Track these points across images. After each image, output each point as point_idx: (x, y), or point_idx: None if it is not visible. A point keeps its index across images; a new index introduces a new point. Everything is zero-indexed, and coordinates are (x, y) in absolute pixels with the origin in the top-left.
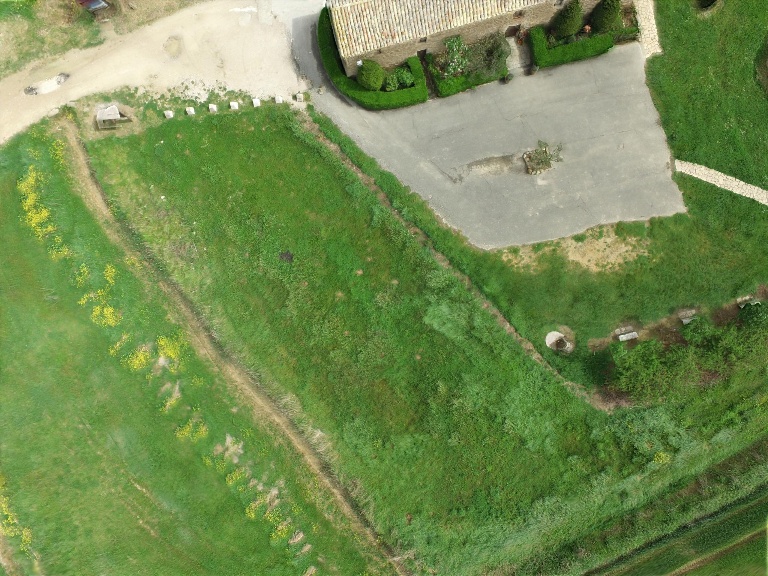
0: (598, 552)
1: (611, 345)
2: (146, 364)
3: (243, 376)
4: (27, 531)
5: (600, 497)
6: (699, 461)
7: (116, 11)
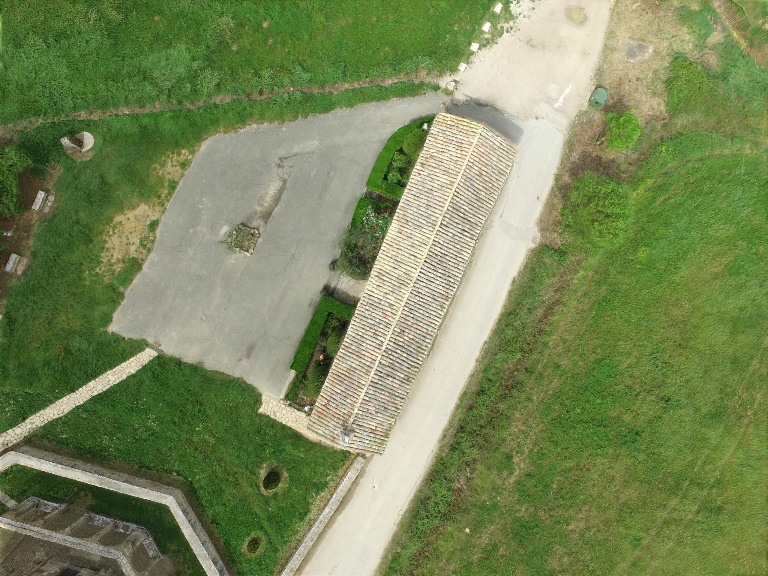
0: None
1: None
2: None
3: None
4: None
5: None
6: None
7: None
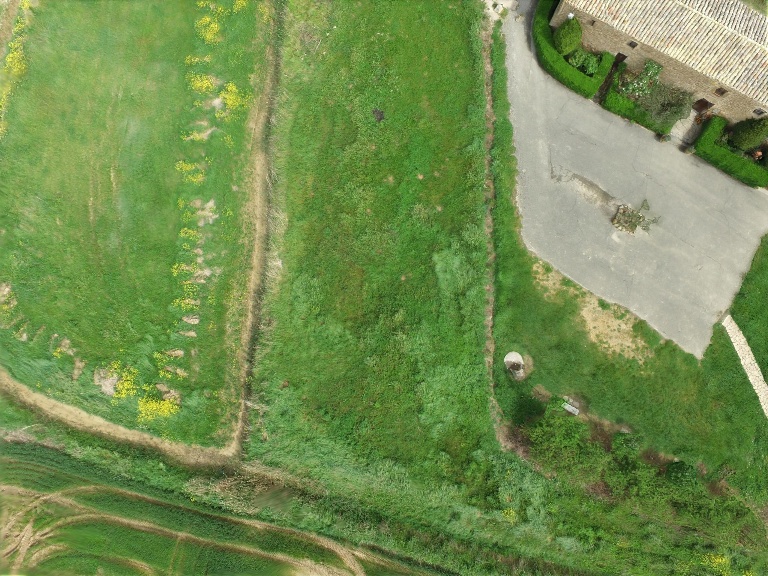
0: (398, 540)
1: (555, 395)
2: (203, 93)
3: (264, 169)
4: (4, 131)
5: (438, 501)
6: (535, 545)
7: None
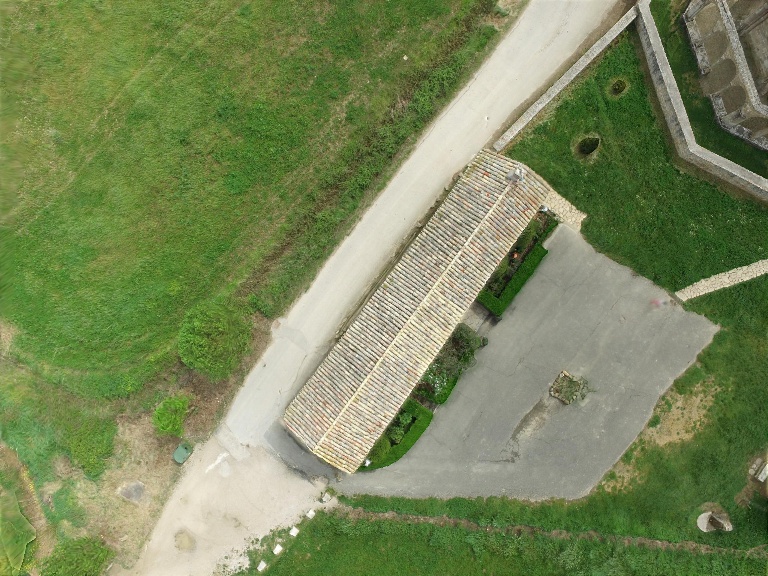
0: None
1: None
2: None
3: None
4: None
5: None
6: None
7: (112, 552)
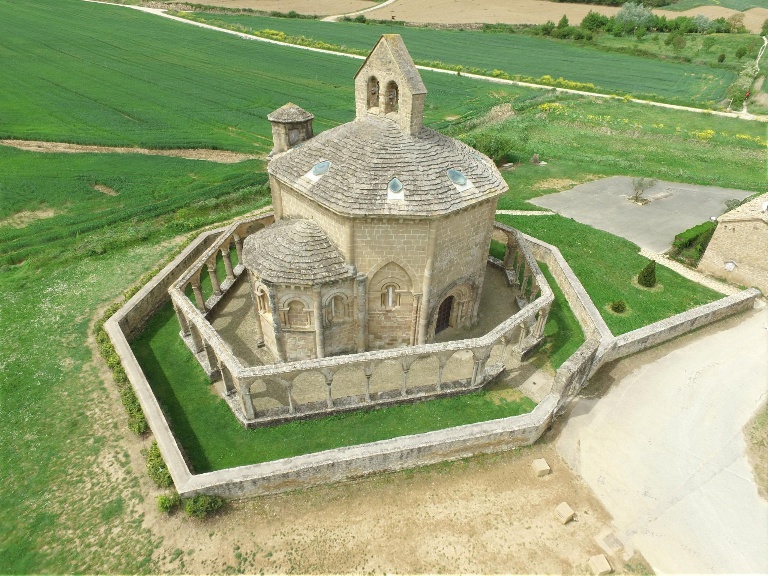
0: (460, 128)
1: None
2: None
3: None
4: None
5: None
6: None
7: None
